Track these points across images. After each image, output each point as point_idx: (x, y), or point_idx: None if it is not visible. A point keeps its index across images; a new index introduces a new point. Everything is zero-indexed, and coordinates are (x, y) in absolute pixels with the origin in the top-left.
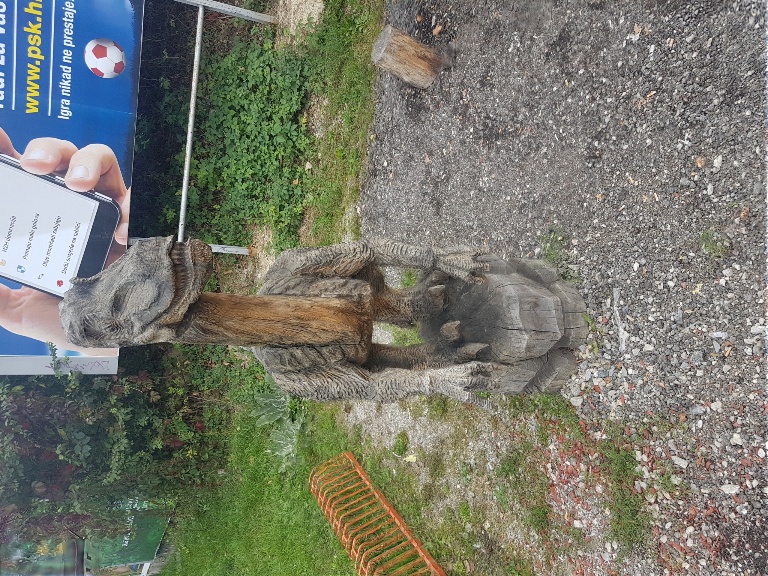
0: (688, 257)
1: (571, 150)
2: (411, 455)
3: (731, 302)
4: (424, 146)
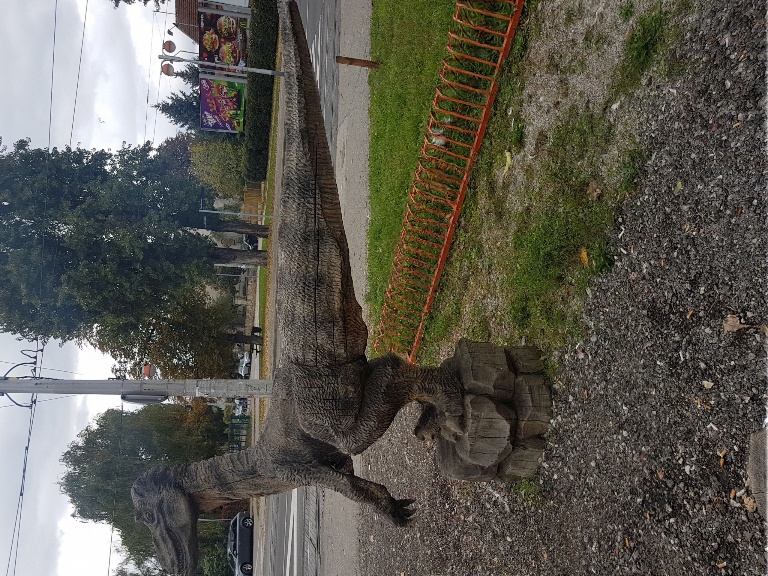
0: (505, 571)
1: (579, 571)
2: (510, 159)
3: (485, 571)
4: (762, 325)
